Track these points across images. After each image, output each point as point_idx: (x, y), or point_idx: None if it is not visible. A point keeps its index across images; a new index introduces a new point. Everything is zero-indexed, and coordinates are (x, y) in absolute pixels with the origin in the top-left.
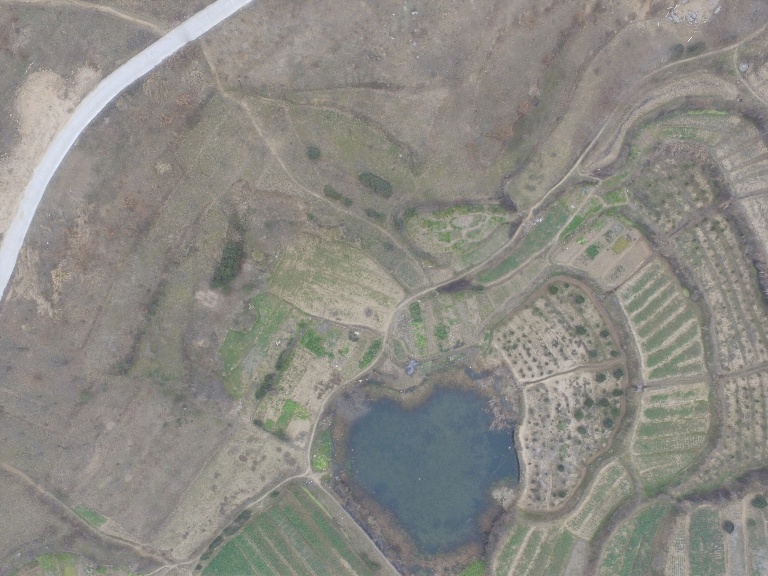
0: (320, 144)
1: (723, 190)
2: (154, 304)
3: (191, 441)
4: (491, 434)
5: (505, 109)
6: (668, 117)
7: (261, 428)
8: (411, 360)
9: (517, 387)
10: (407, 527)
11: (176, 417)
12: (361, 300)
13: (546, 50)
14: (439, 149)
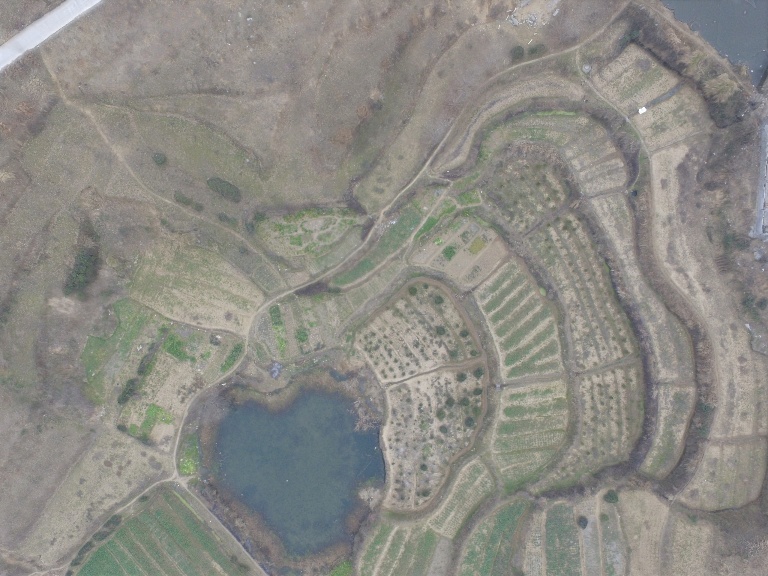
0: (166, 150)
1: (573, 190)
2: (5, 312)
3: (52, 447)
4: (357, 435)
5: (346, 113)
6: (517, 118)
7: (125, 433)
8: (275, 363)
9: (381, 388)
10: (275, 529)
11: (35, 424)
12: (221, 304)
13: (385, 54)
14: (284, 153)
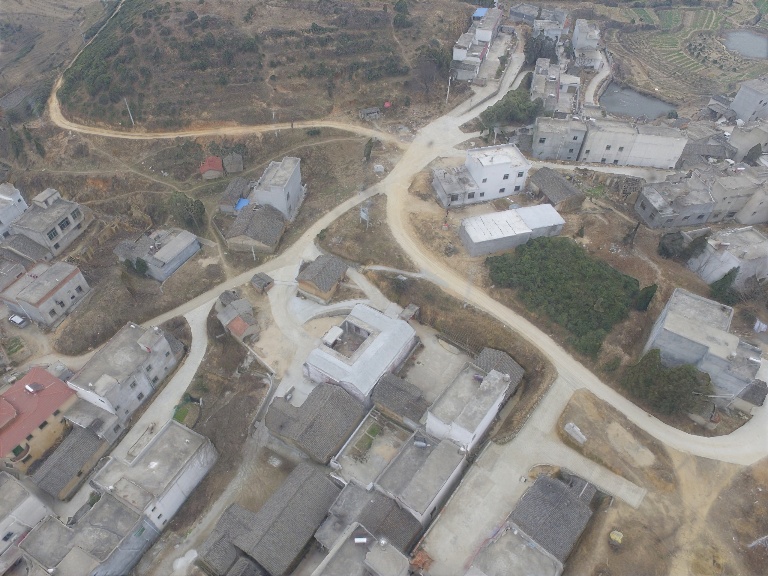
0: None
1: None
2: None
3: None
4: None
5: None
6: None
7: None
8: None
9: None
10: (757, 35)
11: None
12: None
13: None
14: None
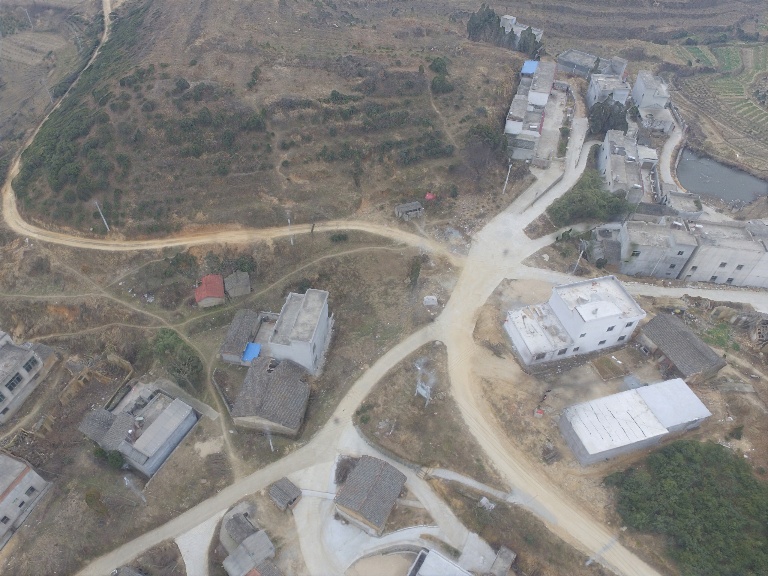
0: None
1: None
2: None
3: None
4: None
5: None
6: None
7: None
8: None
9: None
10: None
11: None
12: None
13: None
14: None
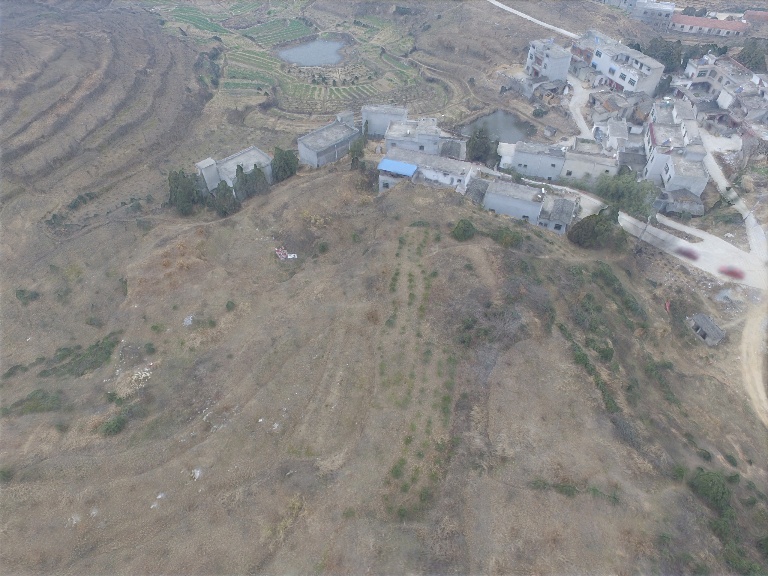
0: None
1: None
2: None
3: None
4: None
5: None
6: None
7: None
8: None
9: None
10: (292, 48)
11: (353, 6)
12: None
13: (472, 49)
14: None
